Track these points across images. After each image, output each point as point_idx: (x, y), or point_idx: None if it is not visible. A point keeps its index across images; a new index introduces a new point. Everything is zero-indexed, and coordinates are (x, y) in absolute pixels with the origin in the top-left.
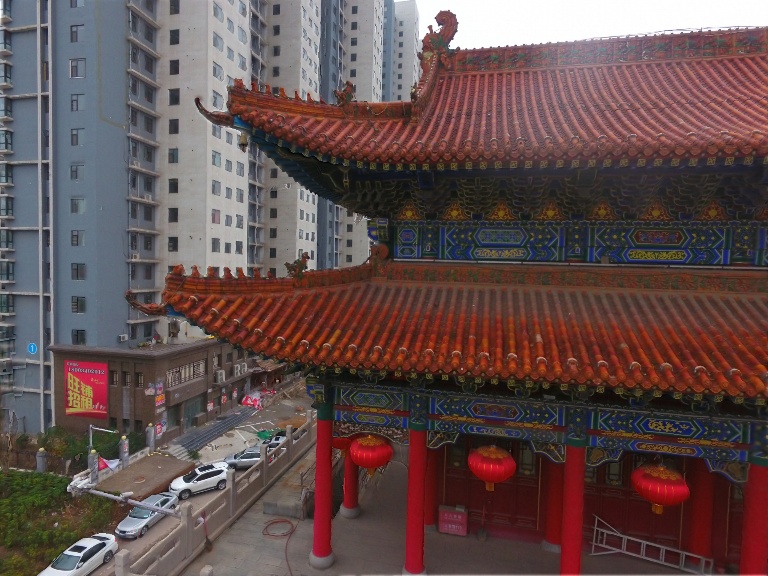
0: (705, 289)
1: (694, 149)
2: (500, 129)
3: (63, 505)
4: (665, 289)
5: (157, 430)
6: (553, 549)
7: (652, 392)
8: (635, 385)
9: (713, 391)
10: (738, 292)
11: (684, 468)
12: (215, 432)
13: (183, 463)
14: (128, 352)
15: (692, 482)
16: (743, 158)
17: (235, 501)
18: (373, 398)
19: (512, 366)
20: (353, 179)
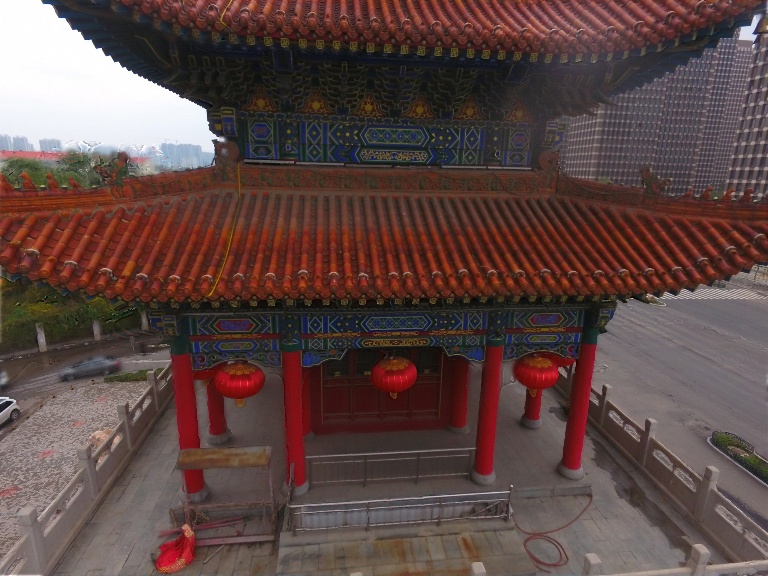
0: None
1: None
2: None
3: None
4: None
5: None
6: None
7: None
8: None
9: None
10: None
11: None
12: None
13: None
14: None
15: None
16: None
17: None
18: None
19: None
20: None
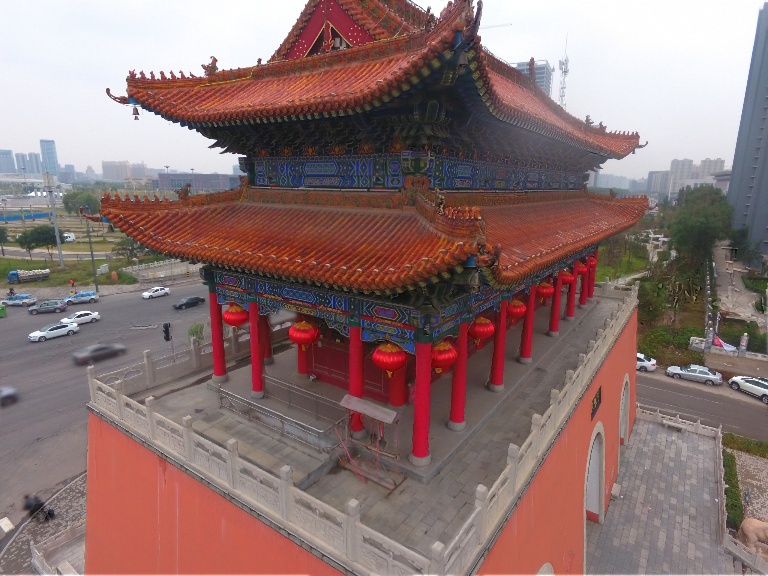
0: None
1: None
2: None
3: (681, 350)
4: None
5: None
6: None
7: None
8: None
9: None
10: None
11: None
12: None
13: None
14: None
15: None
16: None
17: None
18: None
19: None
20: None
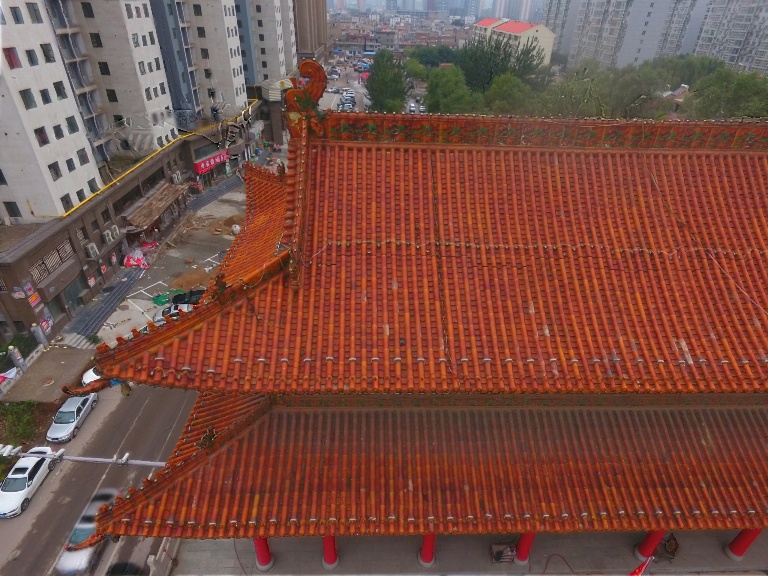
0: (529, 405)
1: (528, 391)
2: (380, 297)
3: None
4: (502, 406)
5: (44, 327)
6: None
7: None
8: None
9: None
10: (549, 406)
11: None
12: (107, 308)
13: (86, 353)
14: None
15: None
16: None
17: None
18: None
19: (391, 532)
20: None
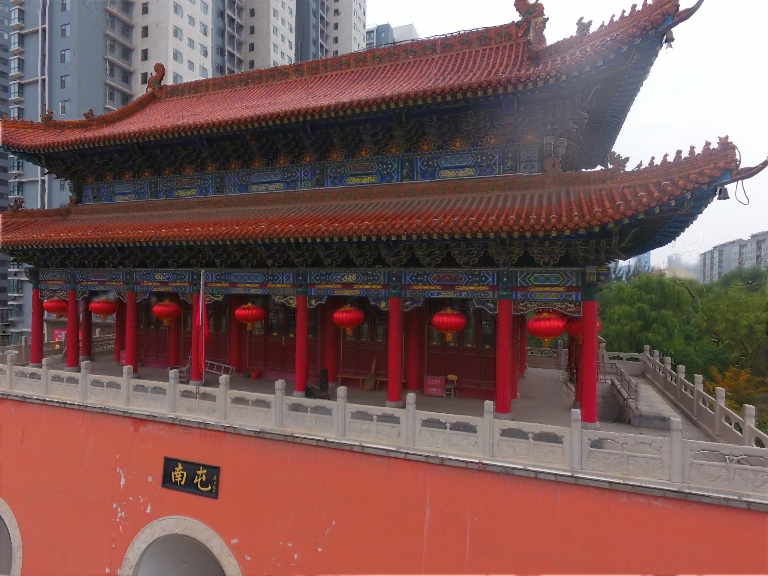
0: (198, 208)
1: (137, 133)
2: None
3: None
4: (183, 210)
5: None
6: (168, 369)
7: (99, 244)
8: (91, 241)
9: (114, 241)
10: (210, 209)
11: (177, 301)
12: None
13: None
14: (94, 321)
15: (230, 325)
16: (156, 136)
17: (28, 355)
18: (53, 275)
19: None
20: (48, 161)
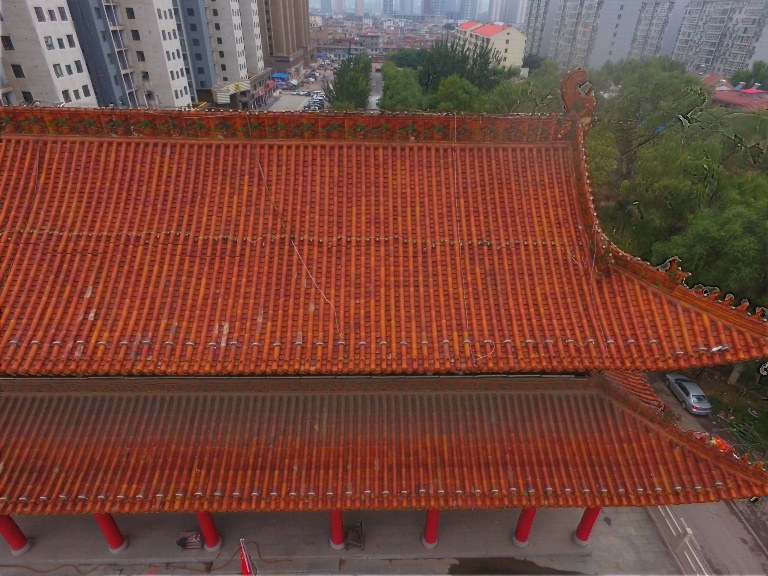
0: (152, 391)
1: (42, 372)
2: None
3: None
4: (126, 391)
5: None
6: None
7: None
8: None
9: None
10: (173, 392)
11: None
12: None
13: None
14: None
15: None
16: None
17: None
18: None
19: None
20: None
